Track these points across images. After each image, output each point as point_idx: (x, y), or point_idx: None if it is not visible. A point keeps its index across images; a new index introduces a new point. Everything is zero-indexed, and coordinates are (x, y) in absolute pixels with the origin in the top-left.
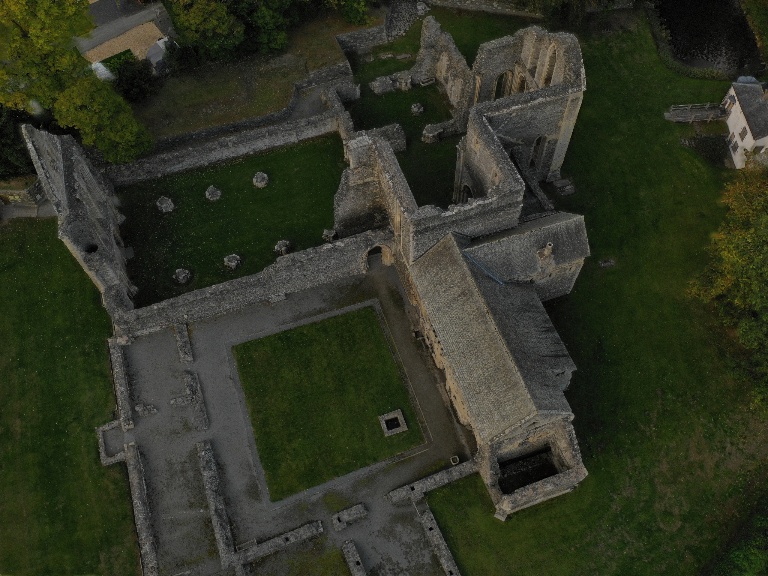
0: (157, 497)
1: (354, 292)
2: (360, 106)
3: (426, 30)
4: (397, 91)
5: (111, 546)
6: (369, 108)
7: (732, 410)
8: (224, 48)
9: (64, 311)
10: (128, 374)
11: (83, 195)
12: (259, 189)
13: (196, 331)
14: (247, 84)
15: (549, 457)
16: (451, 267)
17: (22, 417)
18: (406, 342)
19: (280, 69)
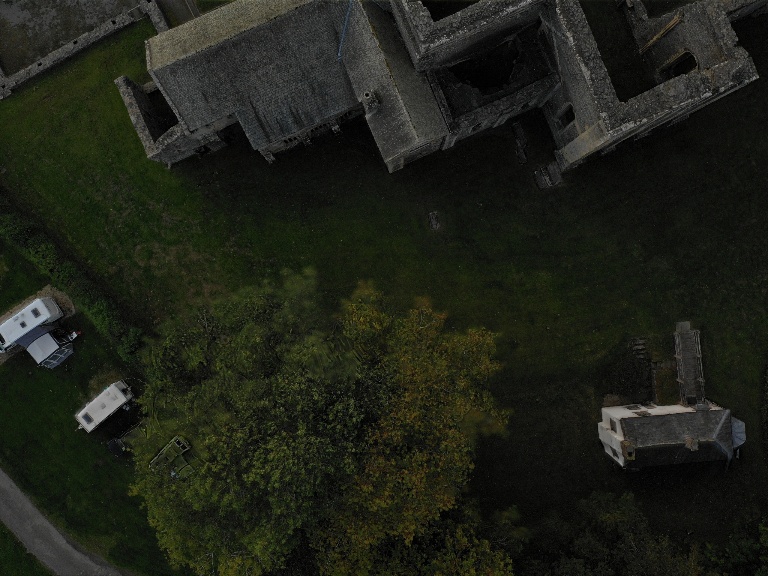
0: None
1: None
2: None
3: None
4: None
5: None
6: None
7: None
8: None
9: None
10: None
11: None
12: None
13: None
14: None
15: None
16: None
17: None
18: None
19: None
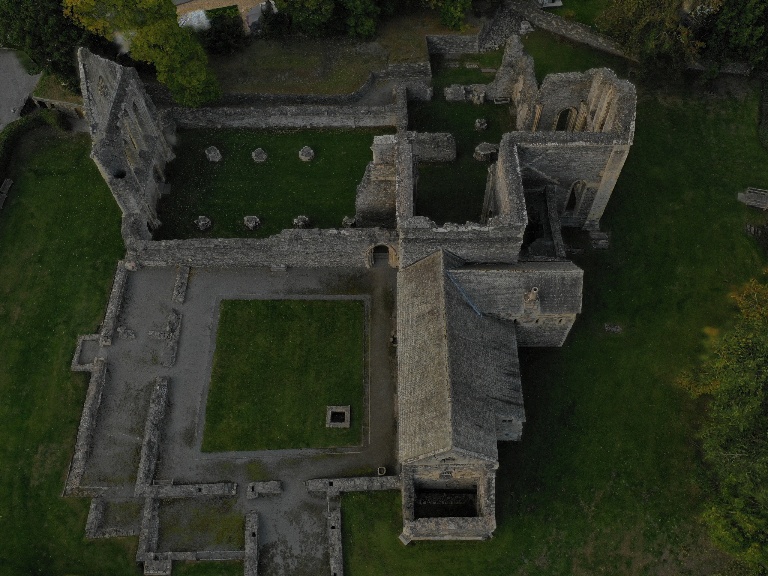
0: (106, 413)
1: (351, 283)
2: (427, 108)
3: (508, 48)
4: (468, 102)
5: (51, 442)
6: (435, 112)
7: (685, 517)
8: (314, 23)
9: (92, 225)
10: (124, 297)
11: (131, 125)
12: (302, 162)
13: (196, 276)
14: (327, 61)
15: (474, 499)
16: (431, 283)
17: (23, 306)
18: (381, 345)
19: (363, 55)
